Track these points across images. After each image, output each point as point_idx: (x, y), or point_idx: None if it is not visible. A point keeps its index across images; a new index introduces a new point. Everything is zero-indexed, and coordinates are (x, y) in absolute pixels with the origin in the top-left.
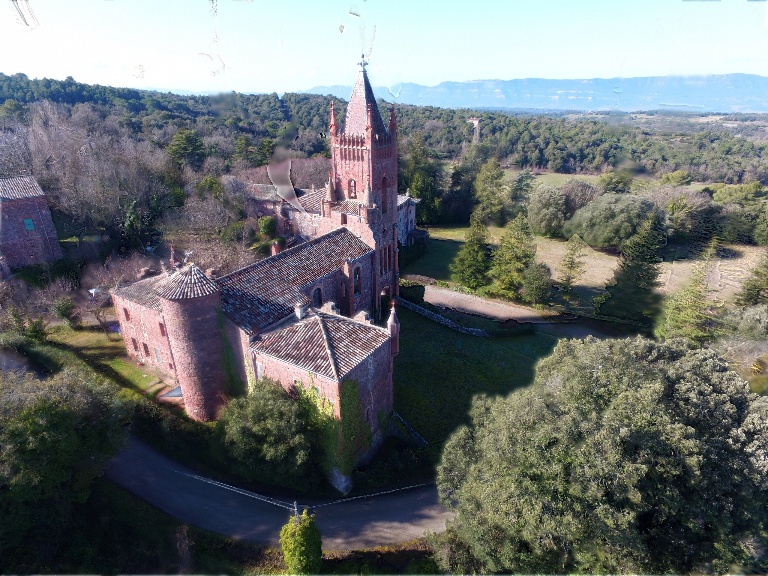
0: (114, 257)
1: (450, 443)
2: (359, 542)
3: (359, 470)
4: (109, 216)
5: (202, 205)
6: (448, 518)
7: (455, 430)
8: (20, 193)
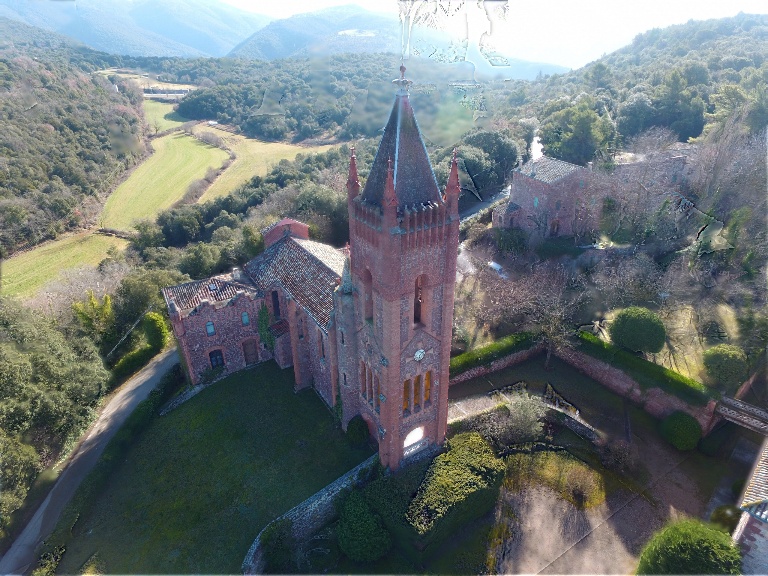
0: (564, 262)
1: (86, 339)
2: (150, 367)
3: (177, 364)
4: (579, 225)
5: (657, 267)
6: (112, 408)
7: (151, 439)
8: (546, 176)
